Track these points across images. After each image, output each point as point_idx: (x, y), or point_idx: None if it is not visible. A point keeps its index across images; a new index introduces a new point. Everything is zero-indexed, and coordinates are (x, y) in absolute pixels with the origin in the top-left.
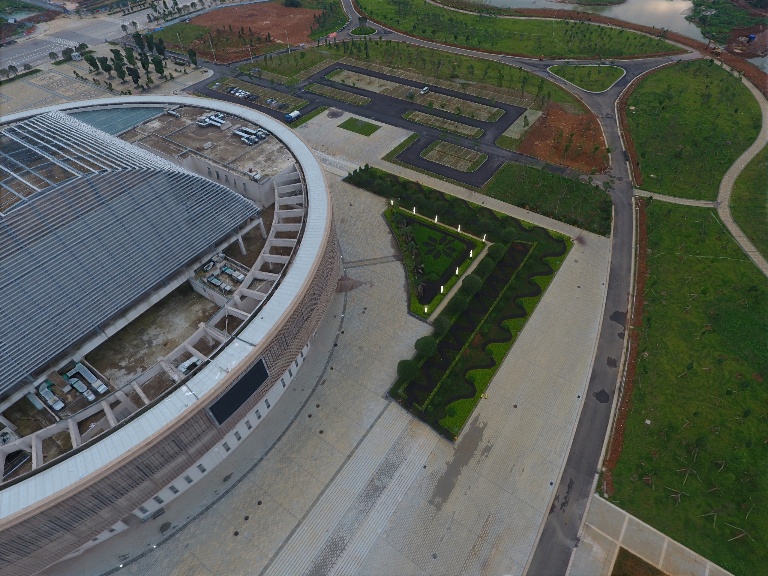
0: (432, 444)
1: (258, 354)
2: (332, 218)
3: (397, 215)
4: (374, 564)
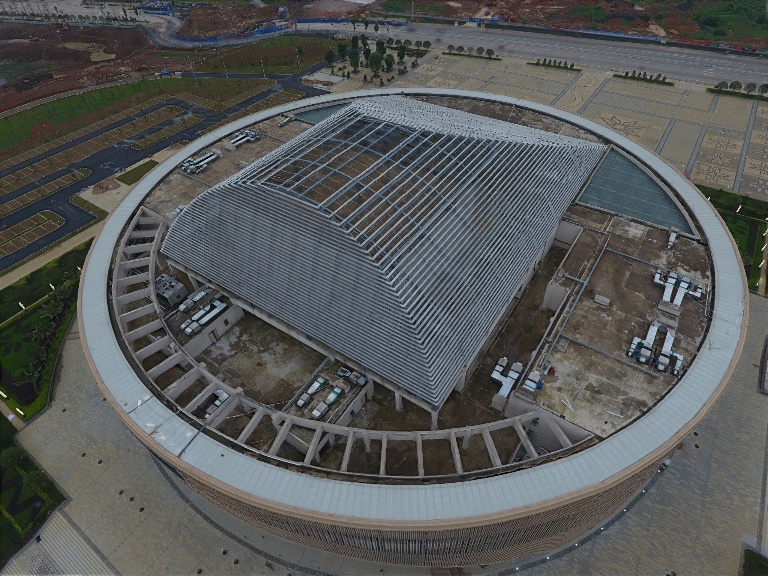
0: None
1: (171, 463)
2: (446, 531)
3: None
4: None
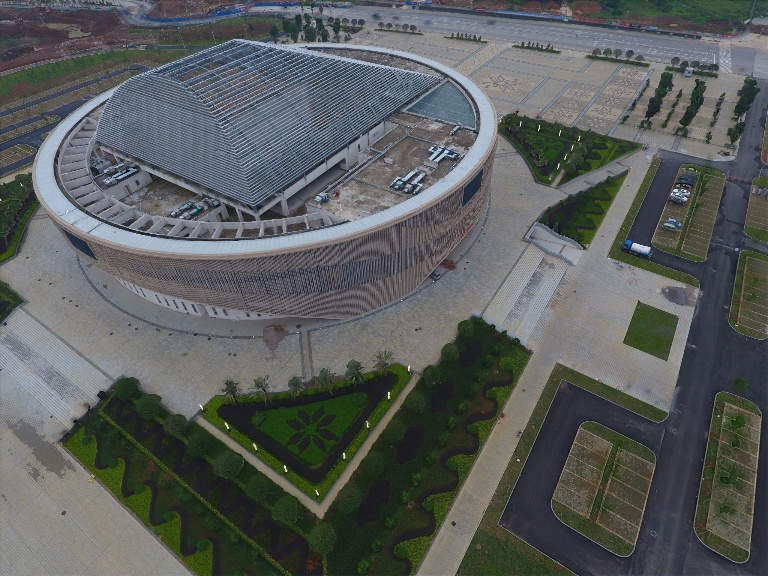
0: (67, 423)
1: (83, 237)
2: (241, 261)
3: (353, 364)
4: (3, 381)
